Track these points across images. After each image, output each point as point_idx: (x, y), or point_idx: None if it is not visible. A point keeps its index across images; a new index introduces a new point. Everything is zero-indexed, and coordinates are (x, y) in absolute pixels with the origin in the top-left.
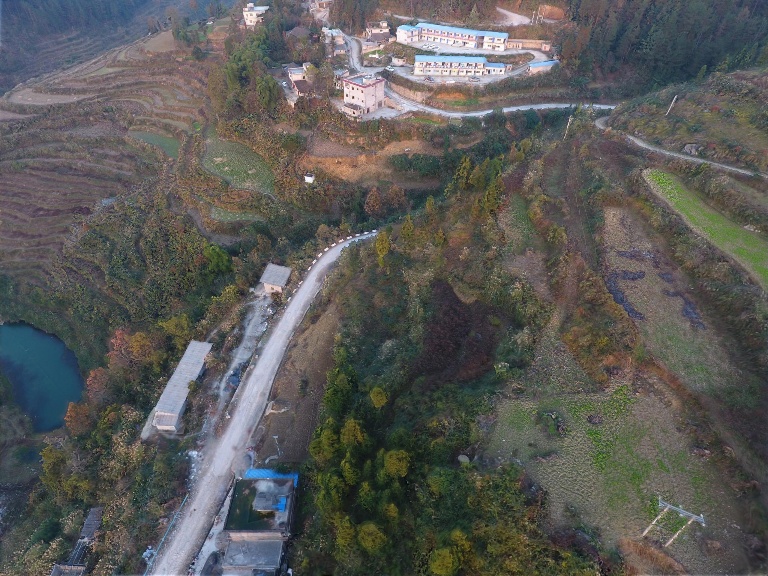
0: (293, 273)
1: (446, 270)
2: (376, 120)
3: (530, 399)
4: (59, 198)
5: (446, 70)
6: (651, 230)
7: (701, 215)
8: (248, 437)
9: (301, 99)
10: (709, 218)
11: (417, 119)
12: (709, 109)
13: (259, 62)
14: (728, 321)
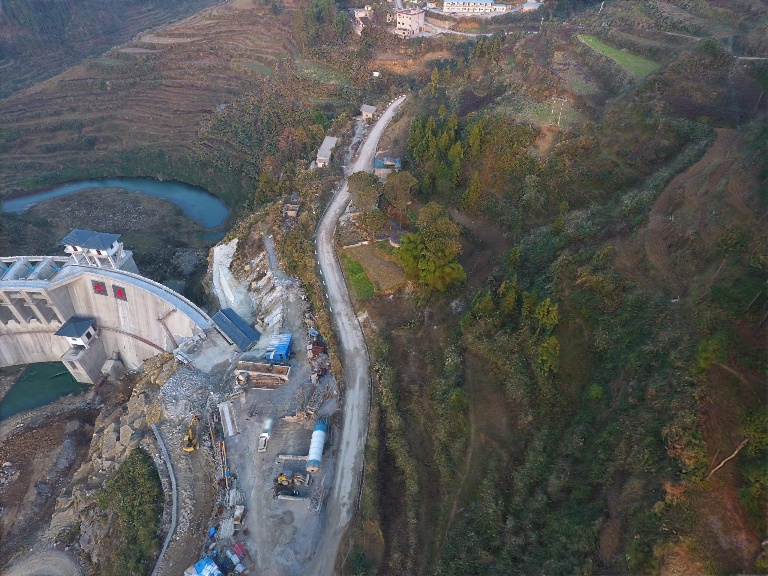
0: (379, 107)
1: (470, 87)
2: (419, 37)
3: (510, 106)
4: (189, 104)
5: (465, 8)
6: (576, 56)
7: (601, 47)
8: (369, 162)
9: (366, 27)
10: (605, 48)
11: (446, 38)
12: (621, 8)
13: (333, 6)
14: (602, 79)
